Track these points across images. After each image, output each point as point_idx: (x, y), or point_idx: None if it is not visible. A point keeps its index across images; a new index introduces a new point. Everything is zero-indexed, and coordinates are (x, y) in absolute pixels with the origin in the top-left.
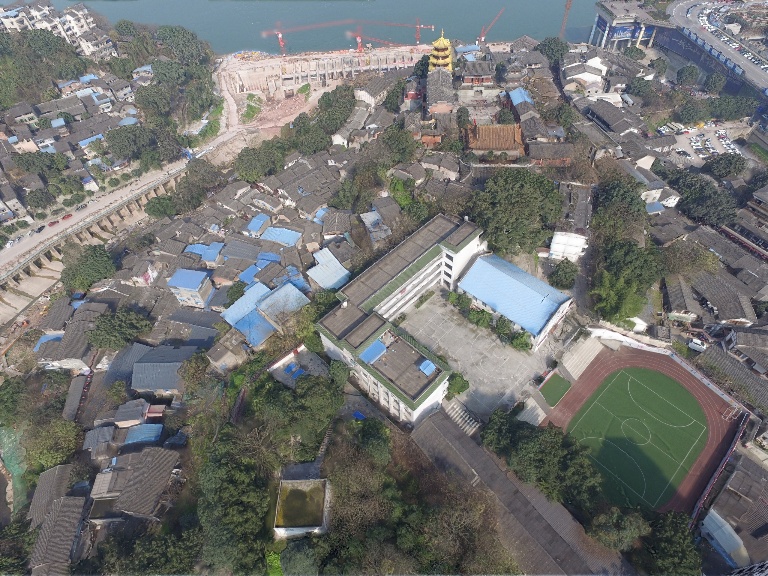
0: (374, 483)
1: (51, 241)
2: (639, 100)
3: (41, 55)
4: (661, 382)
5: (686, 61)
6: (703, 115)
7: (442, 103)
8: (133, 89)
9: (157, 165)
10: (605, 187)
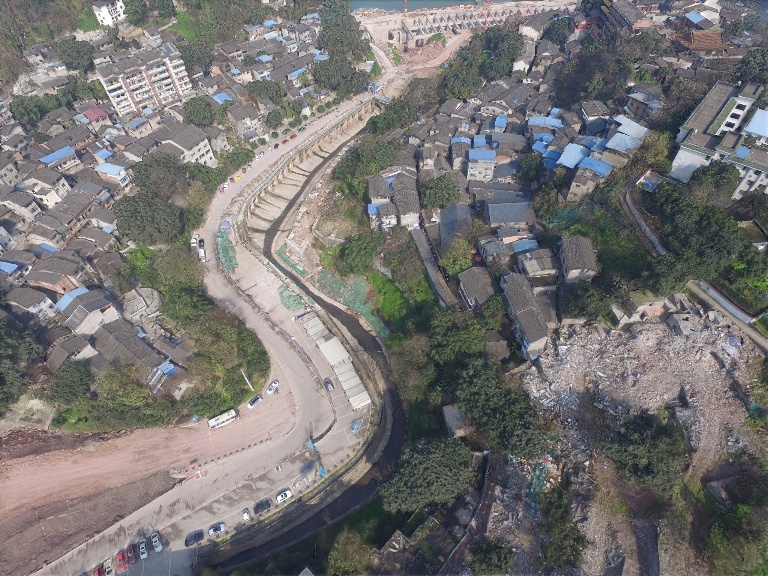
0: None
1: (289, 155)
2: (752, 33)
3: (231, 2)
4: None
5: (765, 8)
6: None
7: (646, 19)
8: (309, 33)
9: (349, 96)
10: None
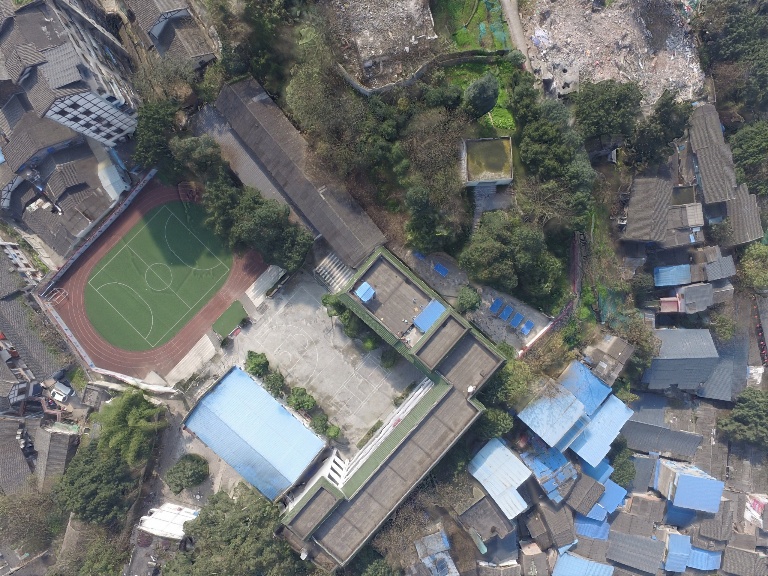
0: (420, 176)
1: None
2: None
3: None
4: (115, 333)
5: None
6: None
7: None
8: None
9: None
10: None
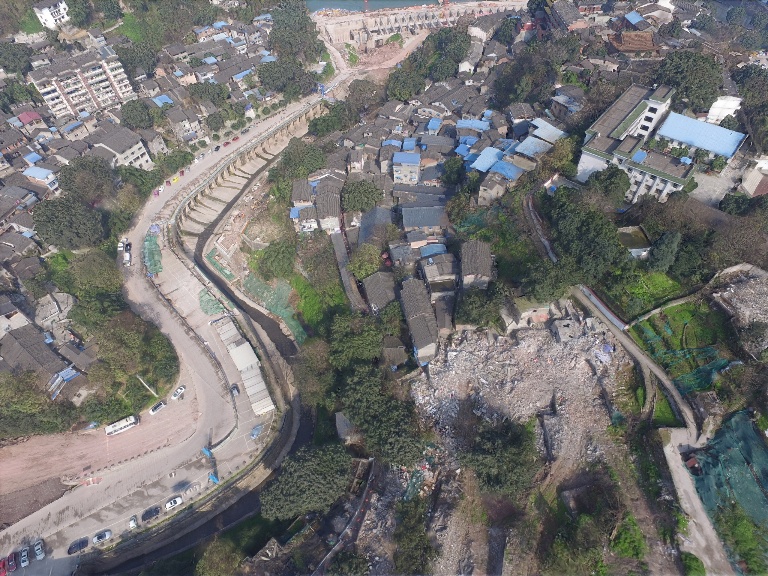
0: (677, 223)
1: (230, 157)
2: (704, 33)
3: (179, 3)
4: None
5: (726, 7)
6: (759, 44)
7: (581, 21)
8: (260, 34)
9: (296, 98)
10: (739, 70)
